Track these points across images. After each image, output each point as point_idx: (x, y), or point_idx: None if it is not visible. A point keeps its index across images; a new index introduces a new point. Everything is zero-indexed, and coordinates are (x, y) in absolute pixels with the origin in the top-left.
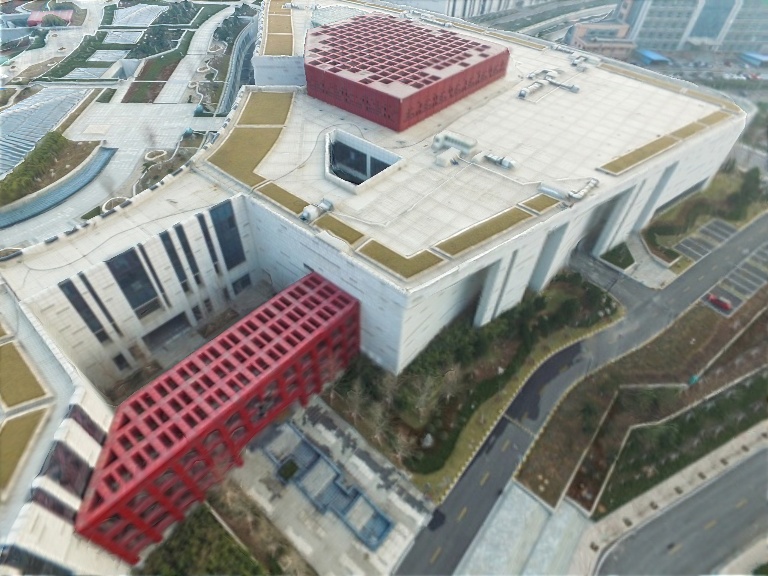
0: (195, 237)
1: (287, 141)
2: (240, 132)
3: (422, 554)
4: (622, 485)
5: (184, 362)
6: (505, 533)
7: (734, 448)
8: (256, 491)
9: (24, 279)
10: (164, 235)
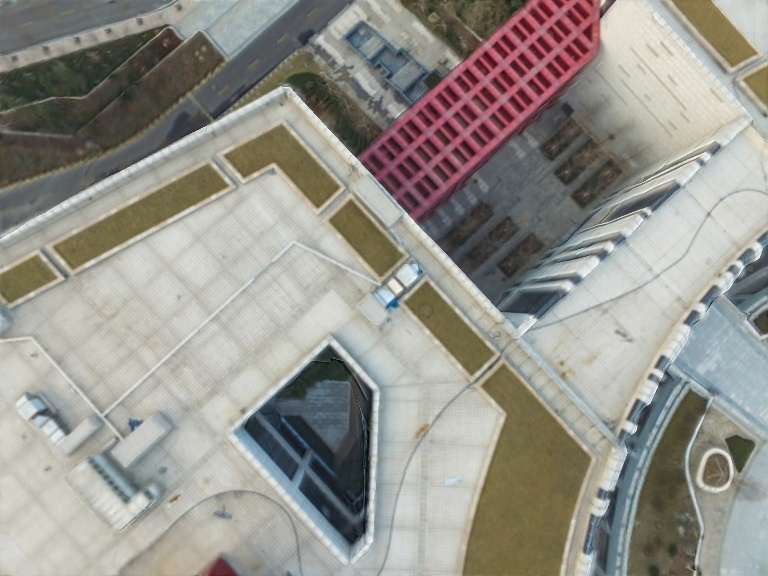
0: None
1: (450, 533)
2: (545, 569)
3: (323, 14)
4: (127, 46)
5: (546, 95)
6: (250, 19)
7: None
8: None
9: (766, 174)
10: (615, 236)
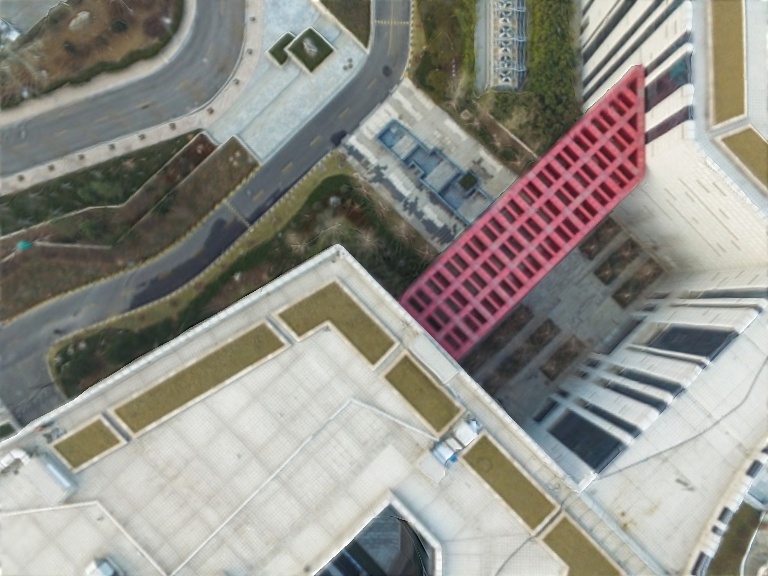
0: (629, 408)
1: None
2: None
3: (355, 114)
4: (162, 153)
5: (592, 223)
6: (282, 122)
7: (32, 178)
8: (495, 168)
9: None
10: (674, 387)
